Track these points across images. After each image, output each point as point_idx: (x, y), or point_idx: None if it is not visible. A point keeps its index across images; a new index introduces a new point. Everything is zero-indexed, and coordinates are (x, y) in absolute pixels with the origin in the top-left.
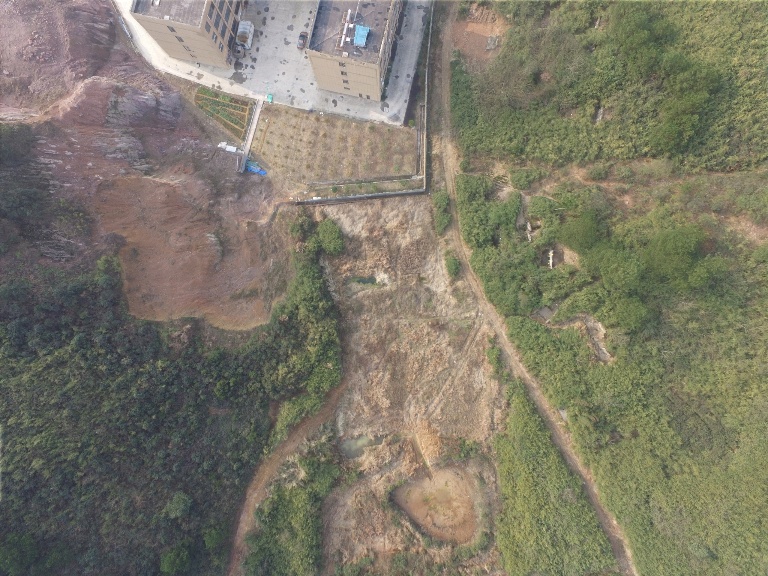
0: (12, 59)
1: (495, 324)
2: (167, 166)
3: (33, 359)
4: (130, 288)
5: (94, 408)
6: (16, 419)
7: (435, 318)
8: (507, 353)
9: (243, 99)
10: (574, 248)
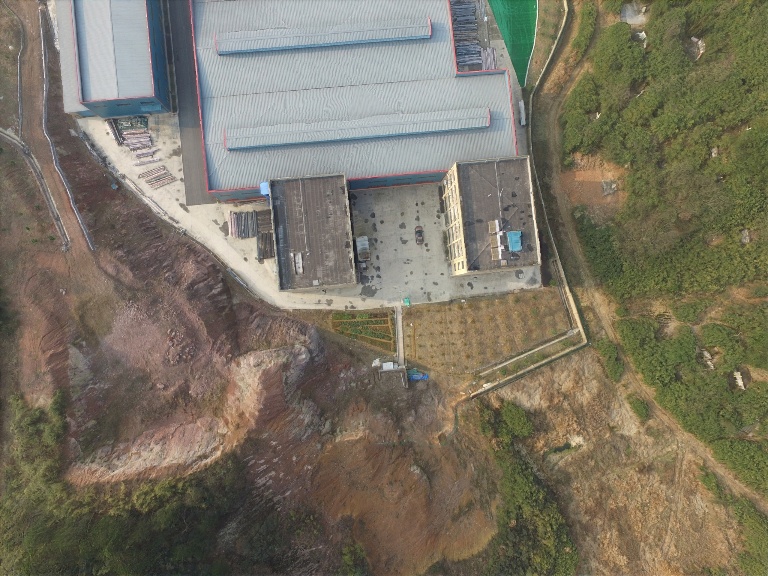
0: (161, 369)
1: (698, 450)
2: (342, 412)
3: None
4: (373, 563)
5: None
6: None
7: (639, 462)
8: (720, 474)
9: (380, 311)
10: (762, 367)
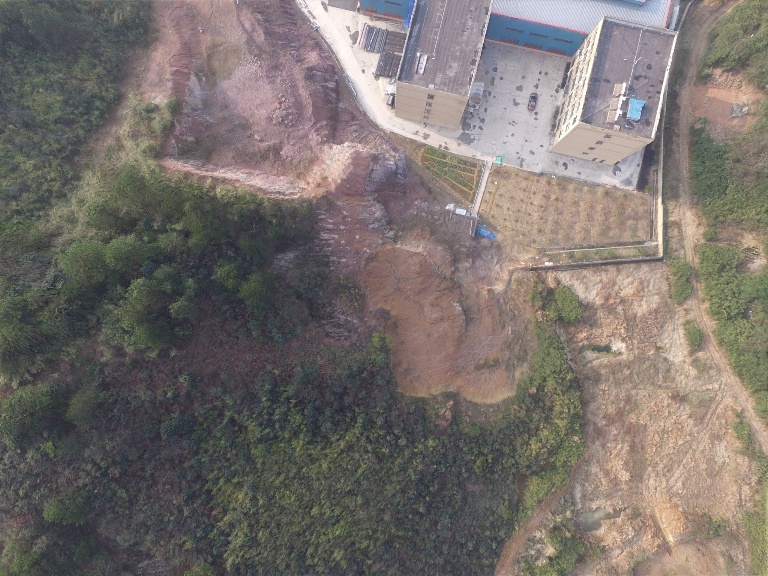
0: (263, 124)
1: (740, 397)
2: (407, 231)
3: (326, 444)
4: (394, 363)
5: (379, 492)
6: (318, 509)
7: (675, 389)
8: (754, 428)
9: (471, 160)
10: None
